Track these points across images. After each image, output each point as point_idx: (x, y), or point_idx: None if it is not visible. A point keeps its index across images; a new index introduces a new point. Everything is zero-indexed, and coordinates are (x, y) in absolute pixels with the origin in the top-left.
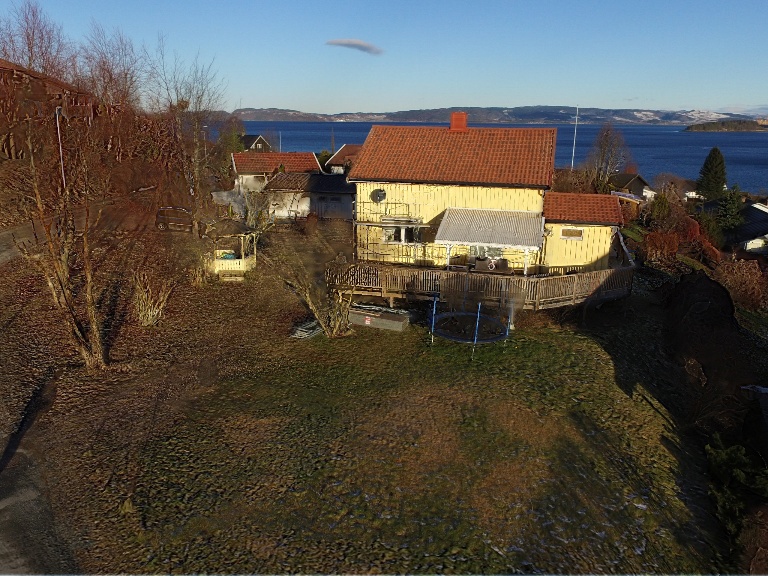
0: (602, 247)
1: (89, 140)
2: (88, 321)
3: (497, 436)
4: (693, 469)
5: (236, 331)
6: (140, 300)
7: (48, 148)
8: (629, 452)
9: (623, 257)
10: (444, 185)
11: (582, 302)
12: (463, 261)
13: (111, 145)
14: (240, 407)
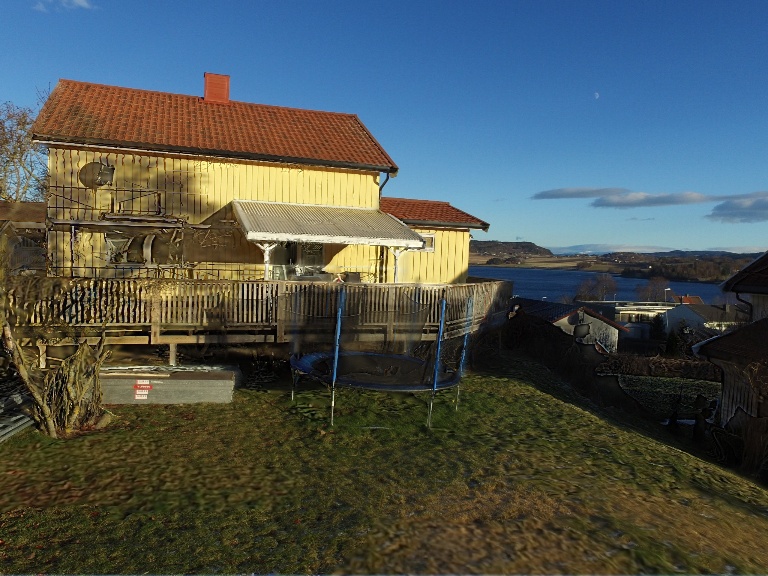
0: (459, 261)
1: None
2: None
3: None
4: None
5: None
6: None
7: None
8: None
9: None
10: (225, 161)
11: (477, 330)
12: None
13: None
14: None
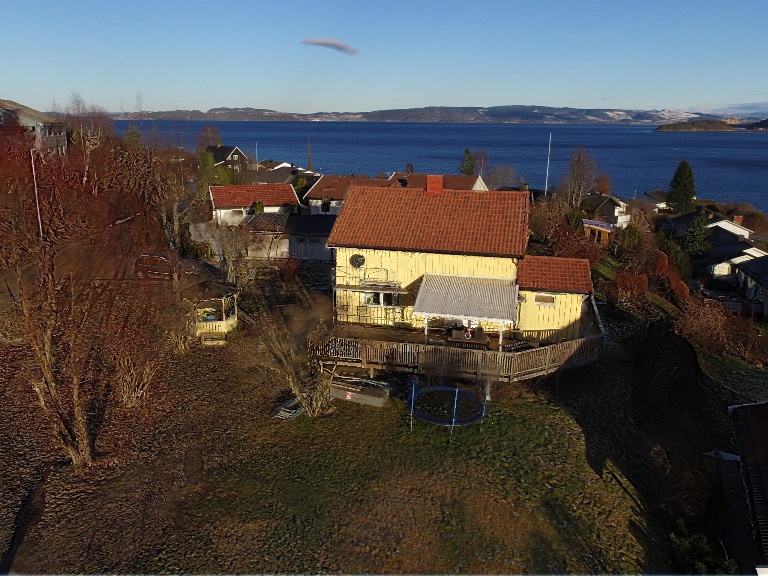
0: (573, 313)
1: (64, 174)
2: (72, 404)
3: (475, 536)
4: (659, 558)
5: (220, 411)
6: (124, 382)
7: (23, 188)
8: (599, 545)
9: (594, 318)
10: (421, 252)
11: (555, 371)
12: (440, 324)
13: (86, 178)
14: (227, 509)
